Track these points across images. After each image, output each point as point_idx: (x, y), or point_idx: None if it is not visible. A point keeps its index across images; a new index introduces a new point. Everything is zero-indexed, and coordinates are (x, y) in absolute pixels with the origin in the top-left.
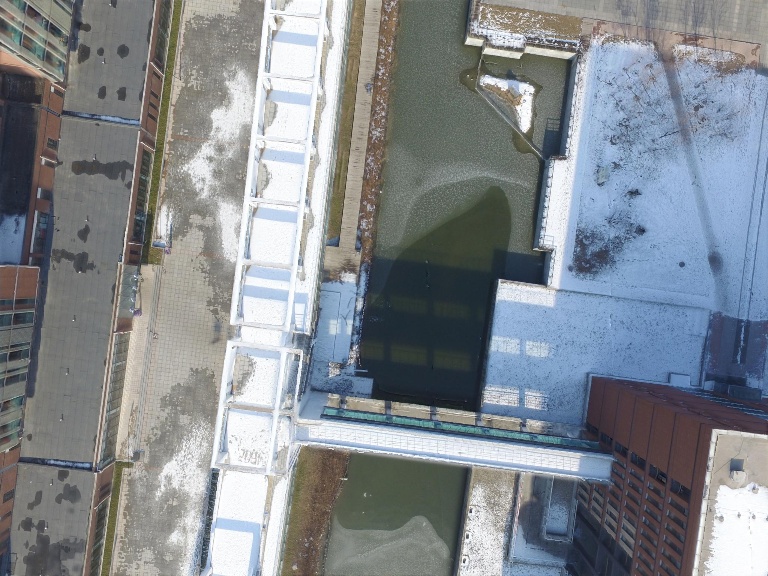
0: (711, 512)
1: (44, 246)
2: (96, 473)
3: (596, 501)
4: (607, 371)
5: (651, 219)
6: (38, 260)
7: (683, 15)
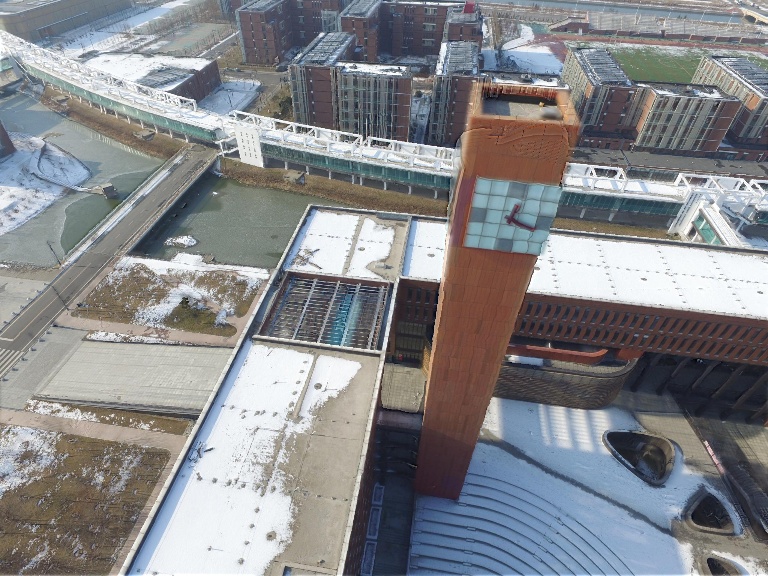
0: None
1: (719, 158)
2: (628, 165)
3: None
4: None
5: None
6: (713, 155)
7: None
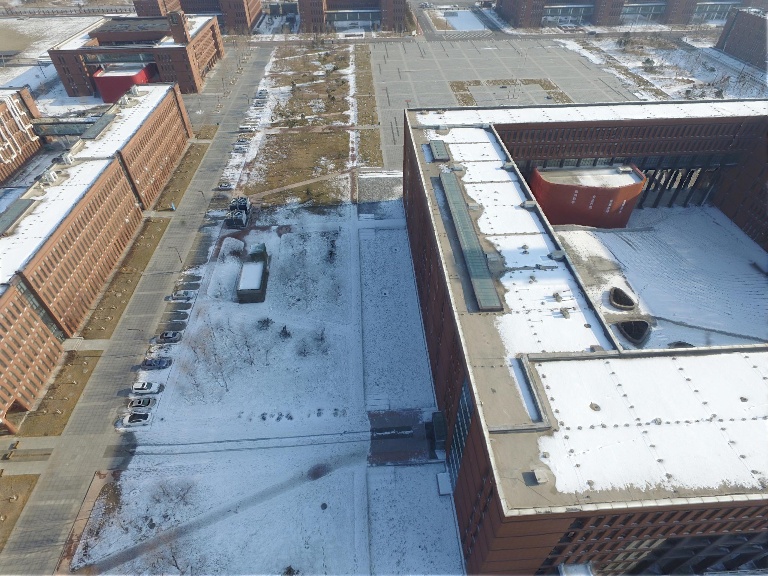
0: (590, 496)
1: None
2: None
3: (615, 568)
4: (458, 570)
5: (275, 555)
6: None
7: (36, 565)
